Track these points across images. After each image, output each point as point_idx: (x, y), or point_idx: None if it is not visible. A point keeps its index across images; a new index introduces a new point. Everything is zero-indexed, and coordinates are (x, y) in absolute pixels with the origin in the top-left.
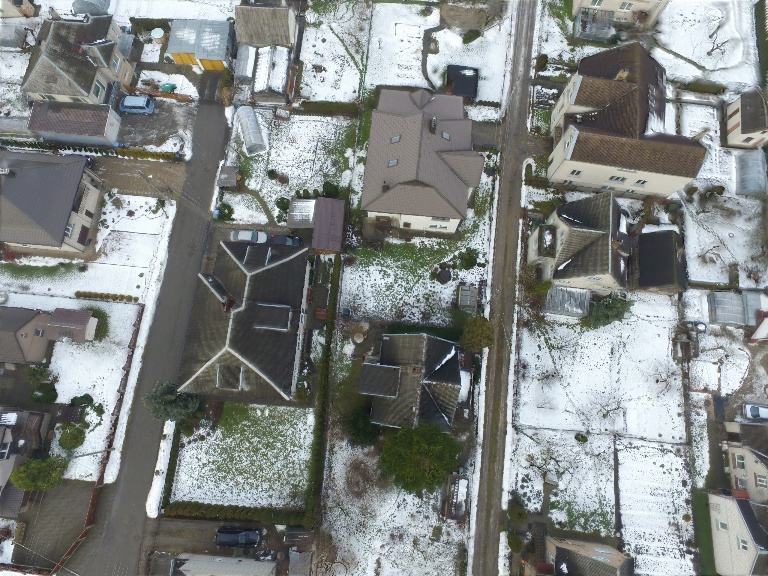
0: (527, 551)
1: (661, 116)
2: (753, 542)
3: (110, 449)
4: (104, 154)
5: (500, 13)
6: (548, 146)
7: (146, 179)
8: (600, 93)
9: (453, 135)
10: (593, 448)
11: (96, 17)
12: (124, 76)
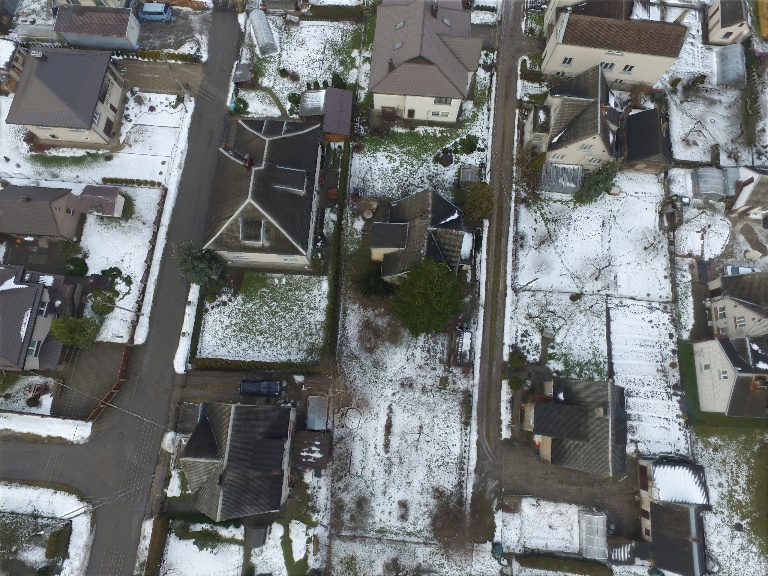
0: (527, 395)
1: (646, 7)
2: (732, 367)
3: (139, 313)
4: (125, 57)
5: None
6: (541, 45)
7: (168, 65)
8: None
9: (453, 23)
10: (587, 307)
11: None
12: None
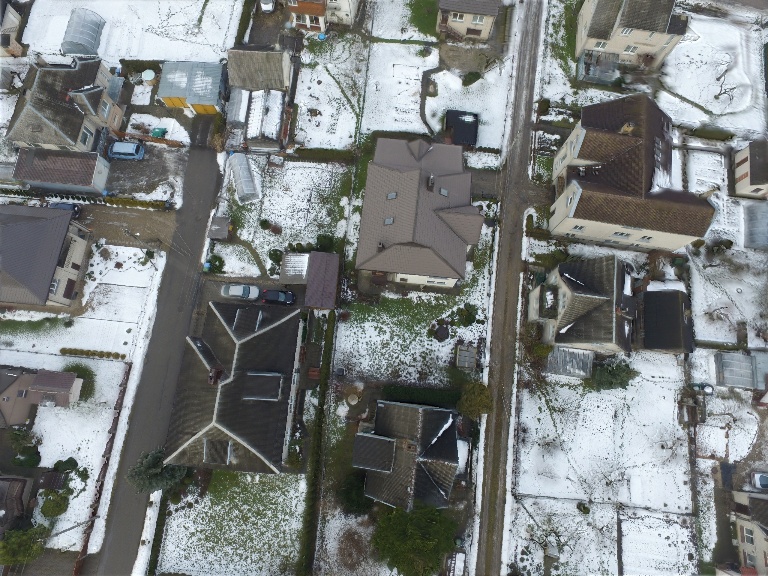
0: None
1: (667, 169)
2: None
3: (94, 518)
4: (92, 202)
5: (501, 54)
6: (550, 195)
7: (133, 236)
8: (604, 147)
9: (451, 191)
10: (596, 518)
11: (84, 62)
12: (113, 121)
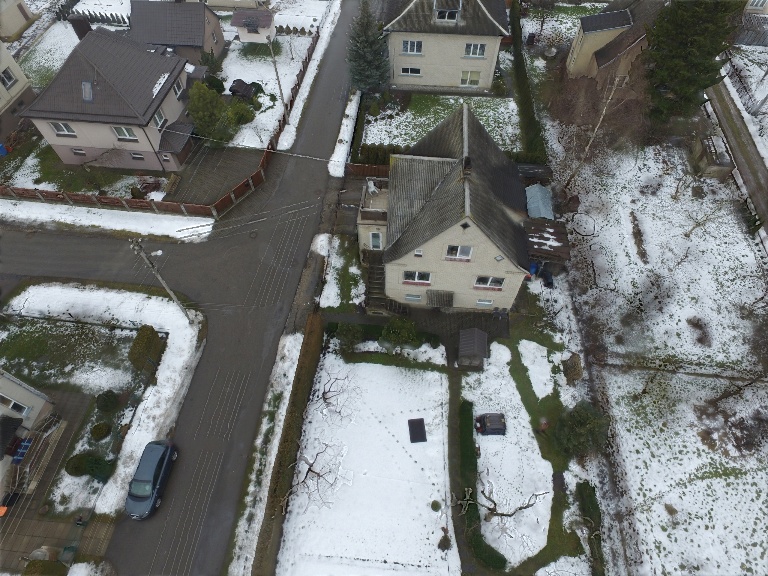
0: None
1: None
2: None
3: None
4: None
5: None
6: None
7: None
8: None
9: None
10: None
11: None
12: None
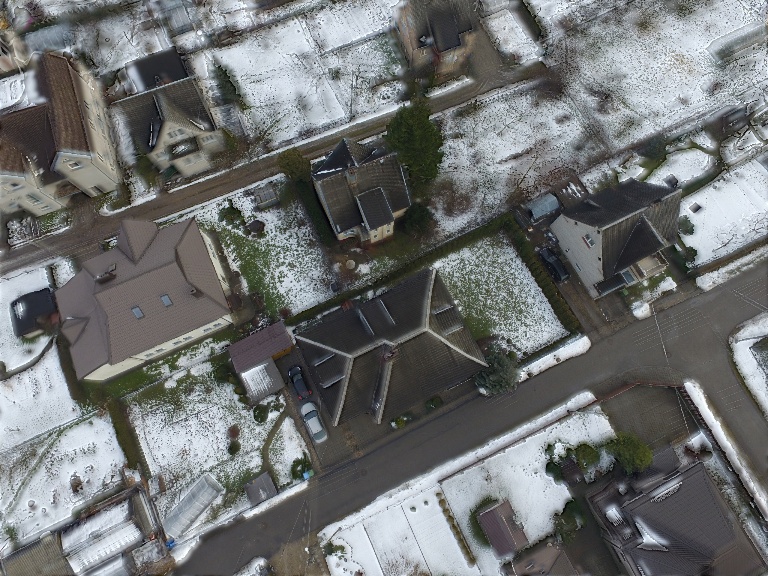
0: None
1: (8, 109)
2: None
3: (571, 412)
4: None
5: None
6: (79, 204)
7: None
8: (3, 157)
9: (108, 265)
10: (333, 67)
11: None
12: None
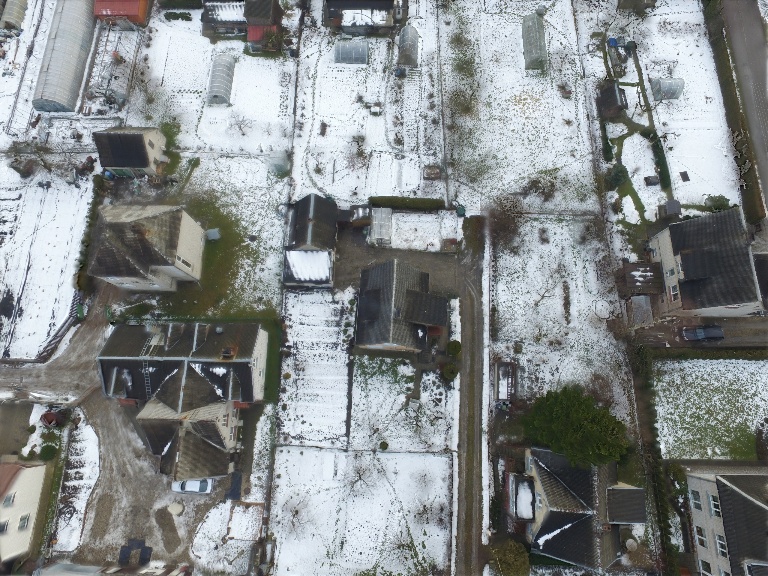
0: None
1: None
2: None
3: None
4: None
5: None
6: None
7: None
8: None
9: None
10: None
11: None
12: None
